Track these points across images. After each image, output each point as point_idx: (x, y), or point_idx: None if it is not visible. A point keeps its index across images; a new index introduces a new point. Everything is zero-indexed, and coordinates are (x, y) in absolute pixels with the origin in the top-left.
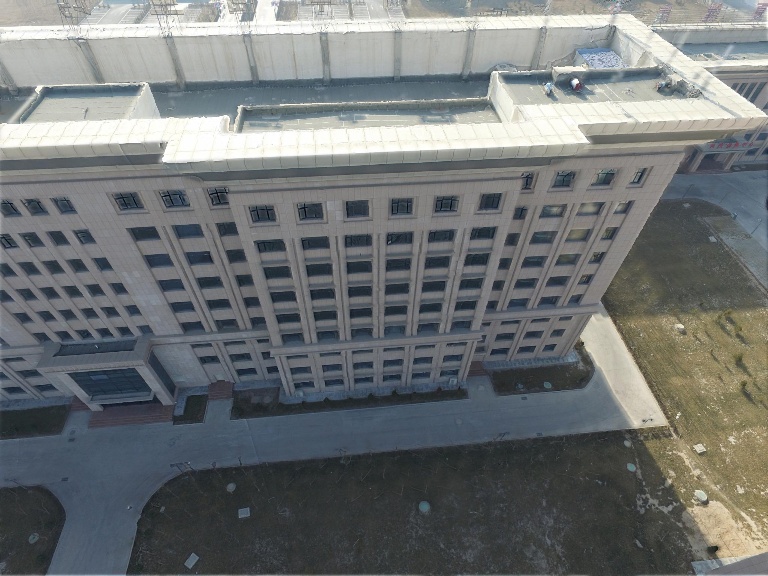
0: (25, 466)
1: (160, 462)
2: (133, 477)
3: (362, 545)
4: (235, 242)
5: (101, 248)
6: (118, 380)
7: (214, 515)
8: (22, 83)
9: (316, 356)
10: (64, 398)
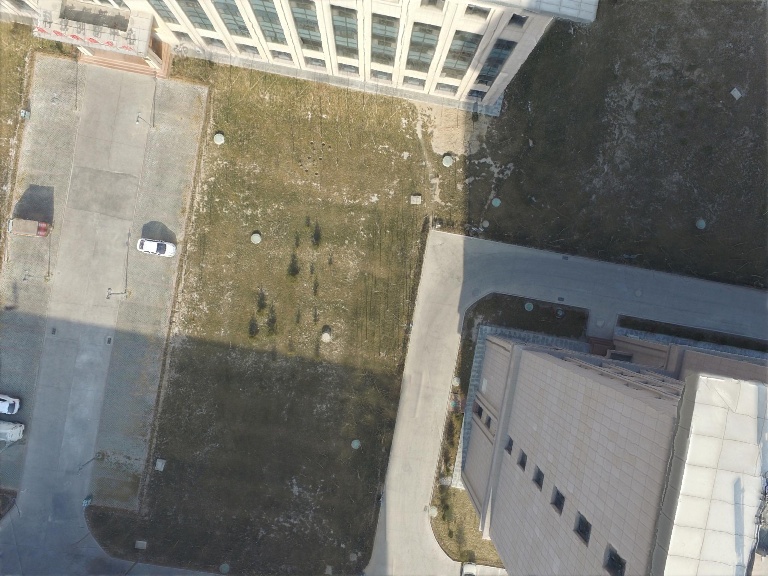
0: None
1: None
2: None
3: (761, 210)
4: None
5: None
6: None
7: None
8: None
9: None
10: None
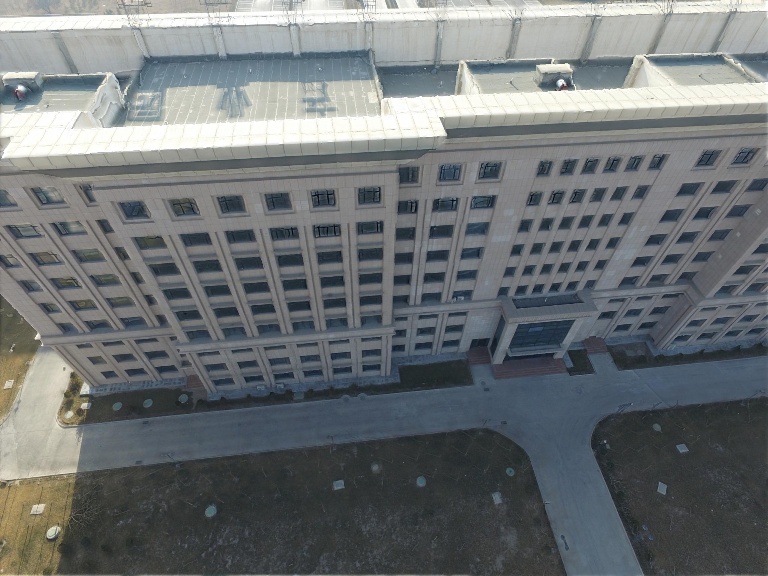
0: (461, 412)
1: (579, 407)
2: (564, 420)
3: None
4: (746, 198)
5: (643, 203)
6: (546, 332)
7: (657, 450)
8: (518, 57)
9: (723, 308)
10: (457, 354)
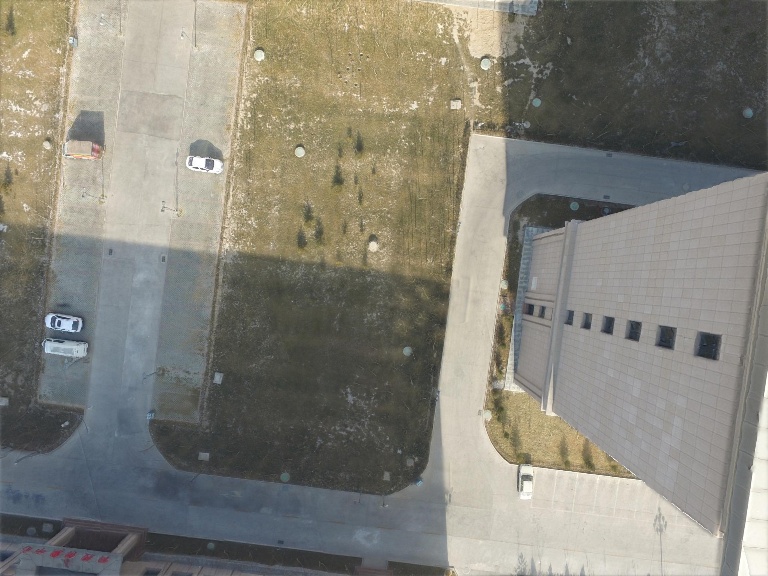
0: None
1: None
2: None
3: None
4: None
5: None
6: None
7: None
8: None
9: None
10: None
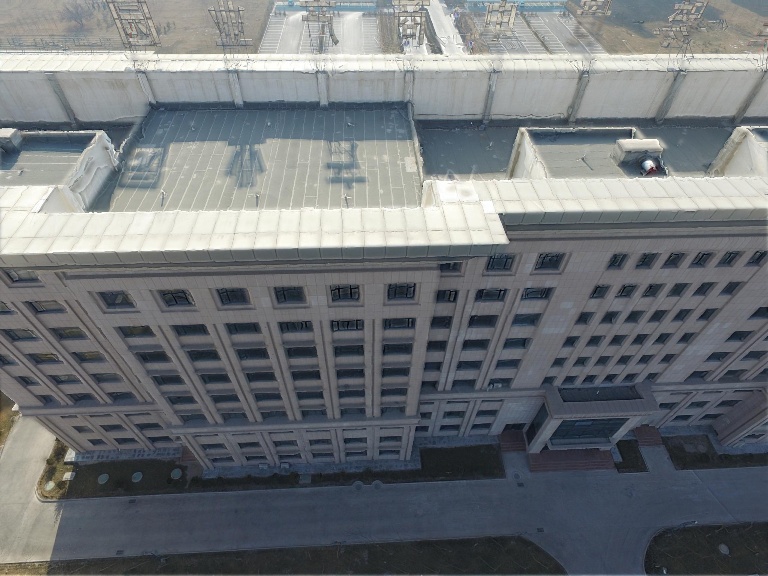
0: (490, 512)
1: (630, 515)
2: (611, 531)
3: None
4: None
5: (732, 300)
6: (594, 426)
7: None
8: (582, 114)
9: None
10: (488, 437)
